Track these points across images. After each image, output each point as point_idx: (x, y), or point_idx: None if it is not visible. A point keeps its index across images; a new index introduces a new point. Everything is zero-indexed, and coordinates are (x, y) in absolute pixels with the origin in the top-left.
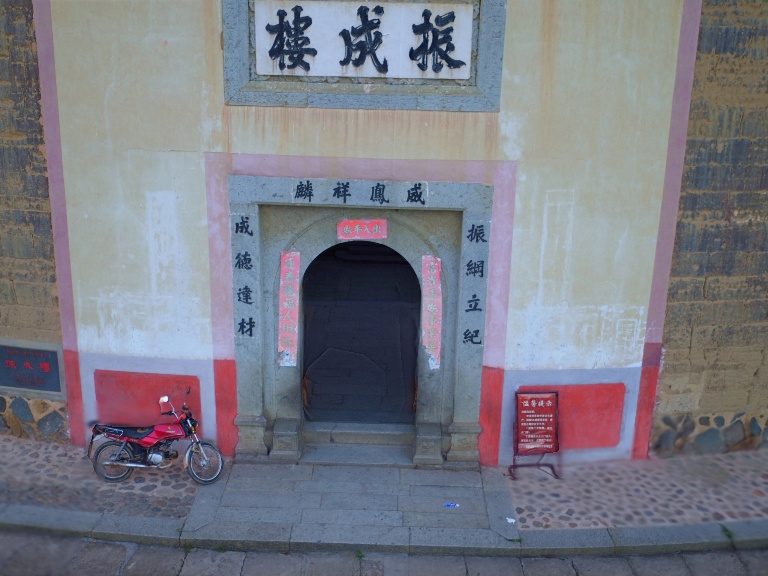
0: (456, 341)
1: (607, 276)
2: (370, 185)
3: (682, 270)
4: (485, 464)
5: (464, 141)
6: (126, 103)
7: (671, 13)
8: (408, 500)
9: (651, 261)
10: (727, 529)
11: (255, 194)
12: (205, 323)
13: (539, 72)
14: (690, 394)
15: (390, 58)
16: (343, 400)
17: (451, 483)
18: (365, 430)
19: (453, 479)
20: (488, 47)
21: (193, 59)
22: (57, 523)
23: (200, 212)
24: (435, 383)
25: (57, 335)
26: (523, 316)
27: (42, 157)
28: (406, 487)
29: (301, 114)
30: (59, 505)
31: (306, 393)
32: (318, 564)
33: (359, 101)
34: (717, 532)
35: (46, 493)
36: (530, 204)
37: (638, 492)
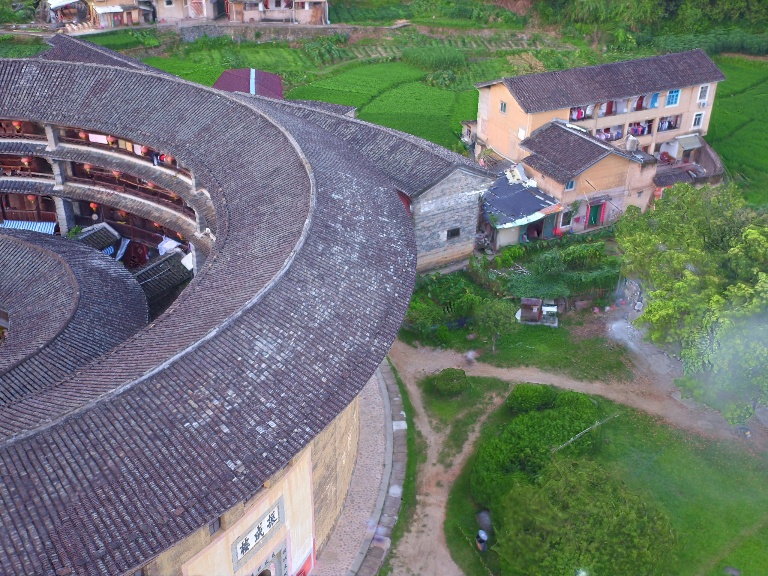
0: None
1: None
2: None
3: None
4: None
5: None
6: None
7: None
8: None
9: None
10: (352, 571)
11: None
12: None
13: None
14: None
15: None
16: None
17: None
18: None
19: None
20: None
21: None
22: None
23: None
24: None
25: None
26: None
27: None
28: None
29: None
30: None
31: None
32: None
33: None
34: (351, 573)
35: None
36: None
37: None
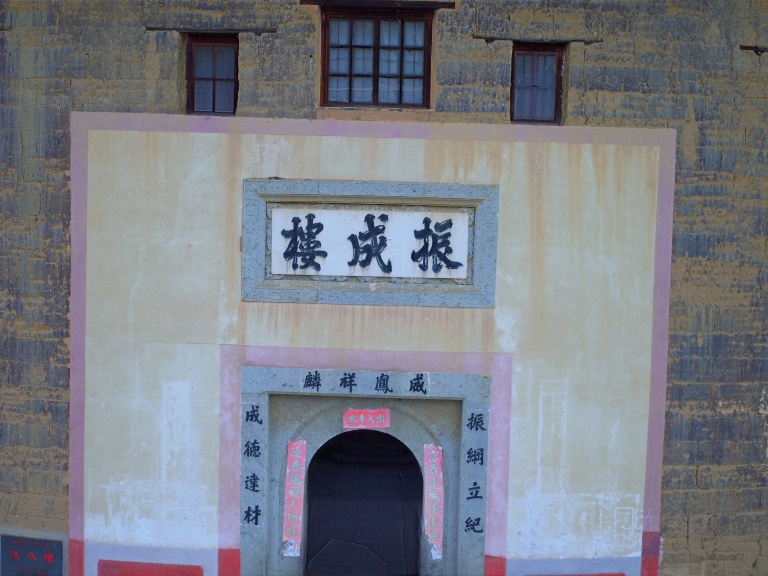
0: (458, 529)
1: (602, 464)
2: (375, 375)
3: (674, 459)
4: None
5: (463, 335)
6: (149, 299)
7: (646, 221)
8: None
9: (643, 449)
10: None
11: (266, 384)
12: (212, 511)
13: (530, 272)
14: None
15: (394, 260)
16: None
17: None
18: None
19: None
20: (483, 250)
21: (214, 260)
22: None
23: (213, 401)
24: (438, 574)
25: (64, 524)
26: (523, 504)
27: (66, 349)
28: None
29: (311, 309)
30: None
31: None
32: None
33: (365, 298)
34: None
35: None
36: (526, 394)
37: None
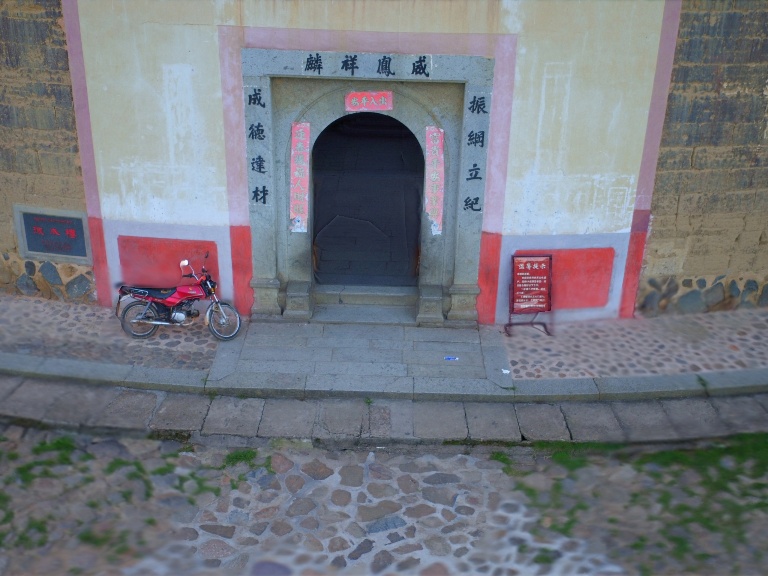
0: (457, 208)
1: (601, 146)
2: (377, 58)
3: (672, 140)
4: (483, 323)
5: (467, 14)
6: None
7: None
8: (412, 354)
9: (643, 132)
10: (702, 379)
11: (267, 67)
12: (221, 191)
13: None
14: (675, 258)
15: None
16: (350, 266)
17: (451, 339)
18: (371, 292)
19: (453, 336)
20: None
21: None
22: (92, 374)
23: (214, 84)
24: (437, 248)
25: (81, 203)
26: (520, 184)
27: (61, 30)
28: (410, 343)
29: None
30: (92, 359)
31: (315, 259)
32: (331, 409)
33: None
34: (693, 381)
35: (79, 348)
36: (529, 76)
37: (623, 347)
